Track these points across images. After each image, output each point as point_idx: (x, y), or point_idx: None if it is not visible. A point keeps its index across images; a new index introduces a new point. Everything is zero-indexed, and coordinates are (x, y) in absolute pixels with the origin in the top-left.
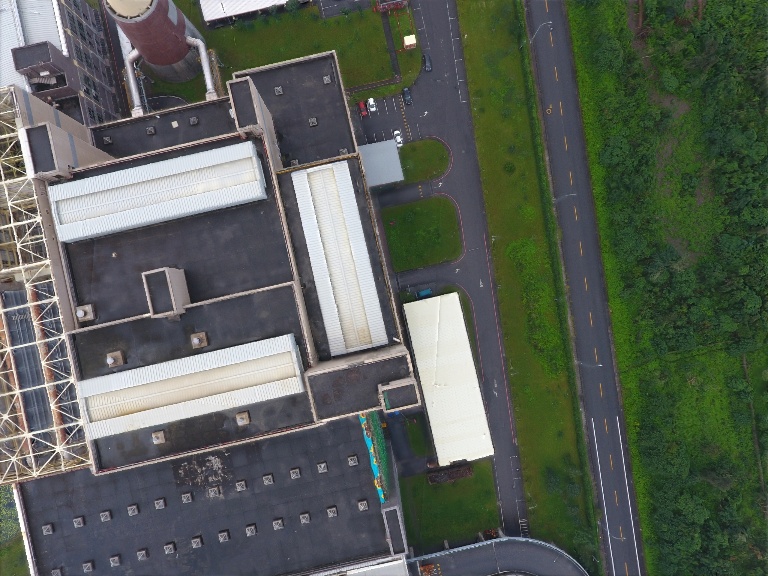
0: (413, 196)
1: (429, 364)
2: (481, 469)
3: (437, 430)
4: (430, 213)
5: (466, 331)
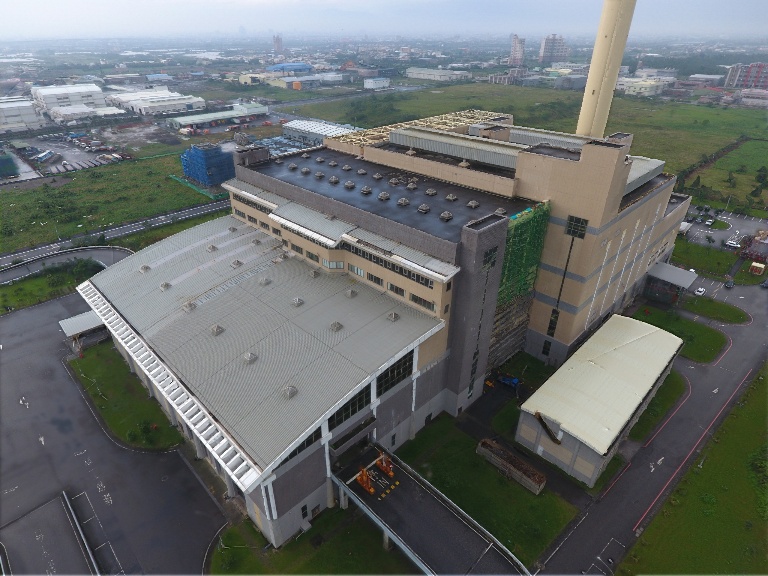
0: (685, 316)
1: (599, 348)
2: (554, 506)
3: (553, 384)
4: (694, 328)
5: (668, 362)
